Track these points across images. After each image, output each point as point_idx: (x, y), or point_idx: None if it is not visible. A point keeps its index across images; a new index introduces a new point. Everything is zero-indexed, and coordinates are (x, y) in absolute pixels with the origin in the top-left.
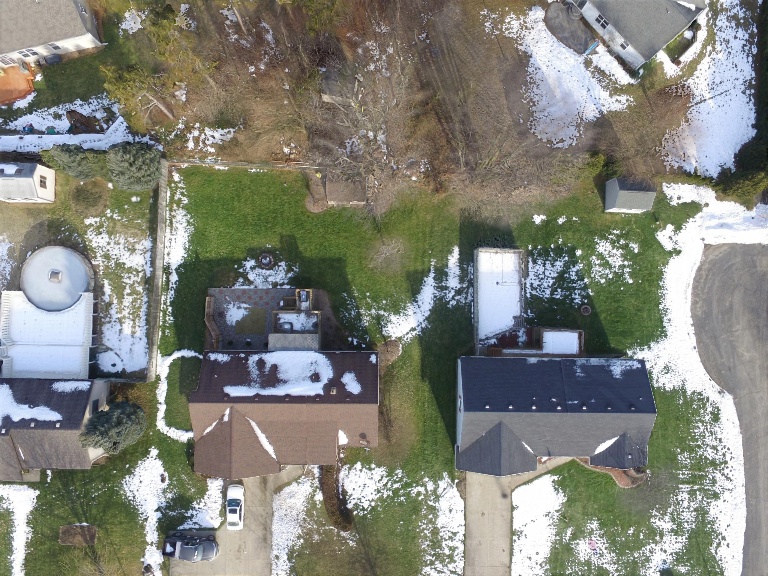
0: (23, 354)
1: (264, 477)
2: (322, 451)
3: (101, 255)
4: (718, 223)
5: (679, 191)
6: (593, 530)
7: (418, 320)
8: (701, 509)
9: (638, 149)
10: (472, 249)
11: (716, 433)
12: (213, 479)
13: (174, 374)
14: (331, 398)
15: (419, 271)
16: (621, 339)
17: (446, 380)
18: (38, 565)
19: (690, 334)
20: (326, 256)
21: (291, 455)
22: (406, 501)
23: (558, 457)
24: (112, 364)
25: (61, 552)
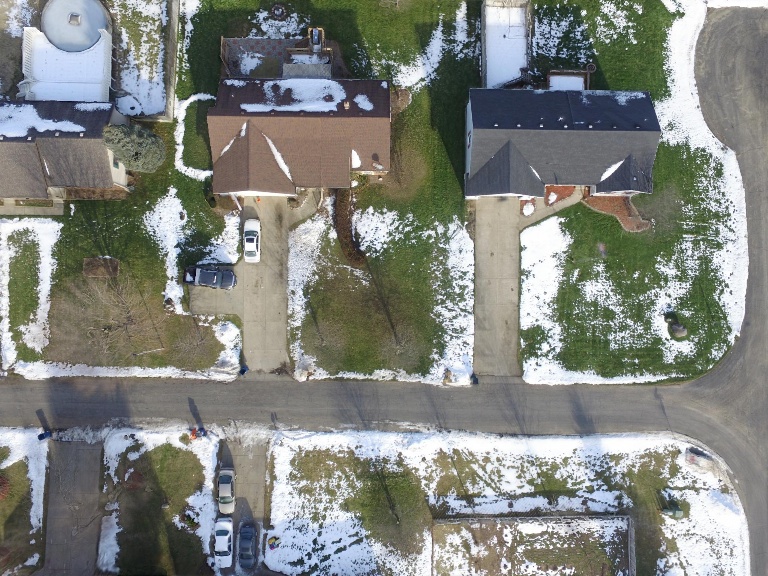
0: (45, 90)
1: (279, 214)
2: (336, 172)
3: (118, 5)
4: None
5: None
6: (599, 272)
7: (427, 71)
8: (705, 258)
9: None
10: (479, 4)
11: (719, 187)
12: (230, 216)
13: (191, 116)
14: (344, 113)
15: (428, 24)
16: None
17: (455, 128)
18: (63, 296)
19: (693, 94)
20: (337, 8)
21: (306, 176)
22: (417, 244)
23: (565, 200)
24: (131, 107)
25: (85, 283)
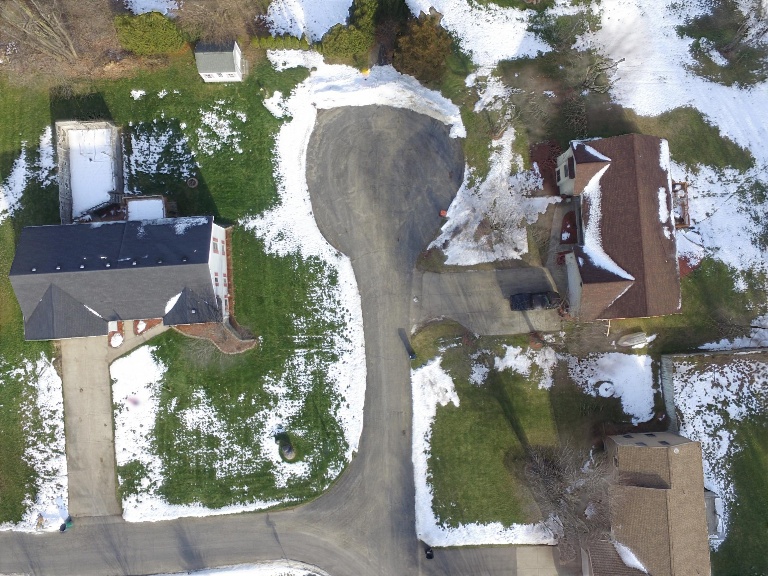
0: None
1: None
2: None
3: None
4: (326, 86)
5: (284, 57)
6: (200, 399)
7: (10, 202)
8: (319, 372)
9: (199, 6)
10: None
11: (334, 296)
12: None
13: None
14: None
15: (9, 153)
16: (231, 209)
17: None
18: None
19: (306, 200)
20: None
21: None
22: (5, 384)
23: (155, 327)
24: None
25: None
